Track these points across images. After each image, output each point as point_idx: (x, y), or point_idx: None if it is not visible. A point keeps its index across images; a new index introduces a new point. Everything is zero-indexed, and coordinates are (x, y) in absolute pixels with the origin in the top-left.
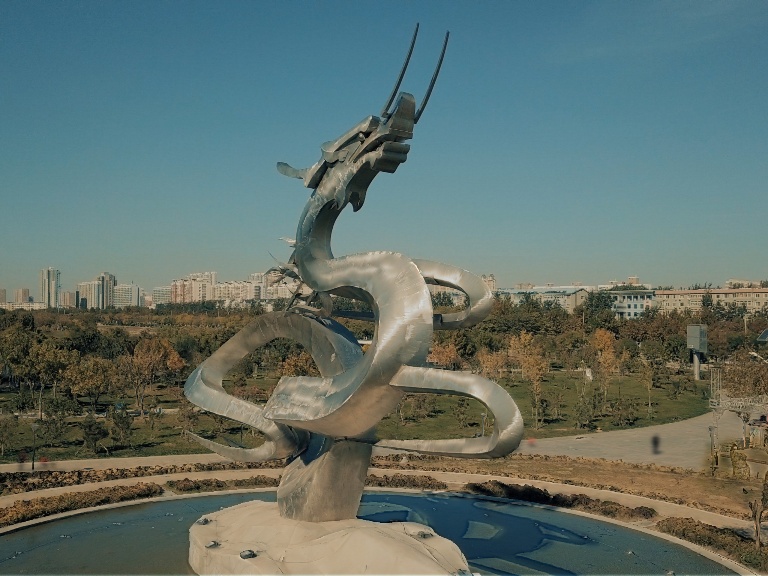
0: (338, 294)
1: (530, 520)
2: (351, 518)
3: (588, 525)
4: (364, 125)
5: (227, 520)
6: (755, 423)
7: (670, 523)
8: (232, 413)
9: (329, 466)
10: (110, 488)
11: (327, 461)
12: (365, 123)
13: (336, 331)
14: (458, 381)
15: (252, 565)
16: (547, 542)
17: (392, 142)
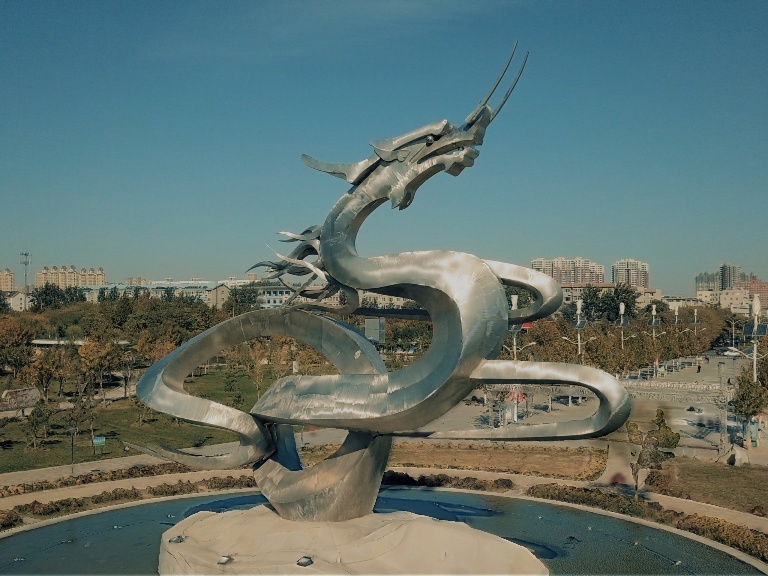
0: (379, 291)
1: (423, 501)
2: (370, 513)
3: (474, 500)
4: (436, 128)
5: (202, 534)
6: (471, 403)
7: (541, 489)
8: (212, 418)
9: (362, 463)
10: None
11: (363, 458)
12: (438, 126)
13: (346, 328)
14: (562, 371)
15: (318, 571)
16: (464, 518)
17: (469, 148)
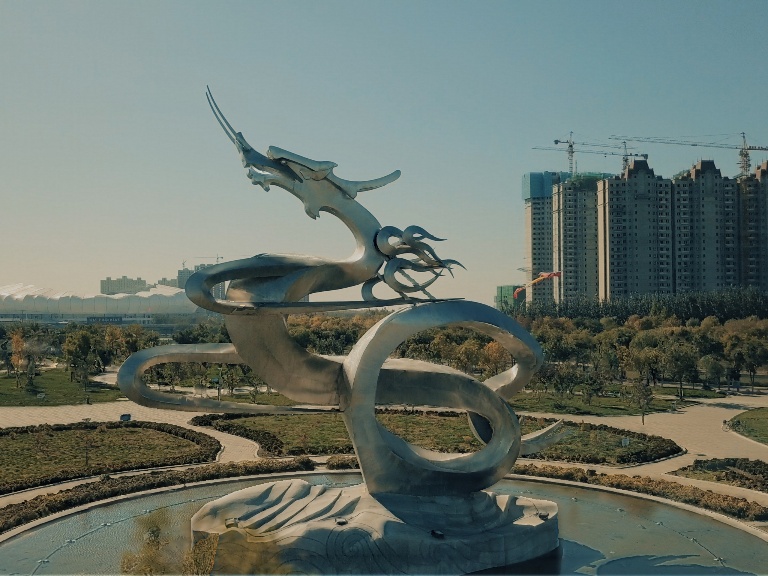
0: None
1: None
2: None
3: None
4: None
5: None
6: None
7: None
8: None
9: None
10: (726, 496)
11: None
12: None
13: None
14: None
15: None
16: None
17: None
